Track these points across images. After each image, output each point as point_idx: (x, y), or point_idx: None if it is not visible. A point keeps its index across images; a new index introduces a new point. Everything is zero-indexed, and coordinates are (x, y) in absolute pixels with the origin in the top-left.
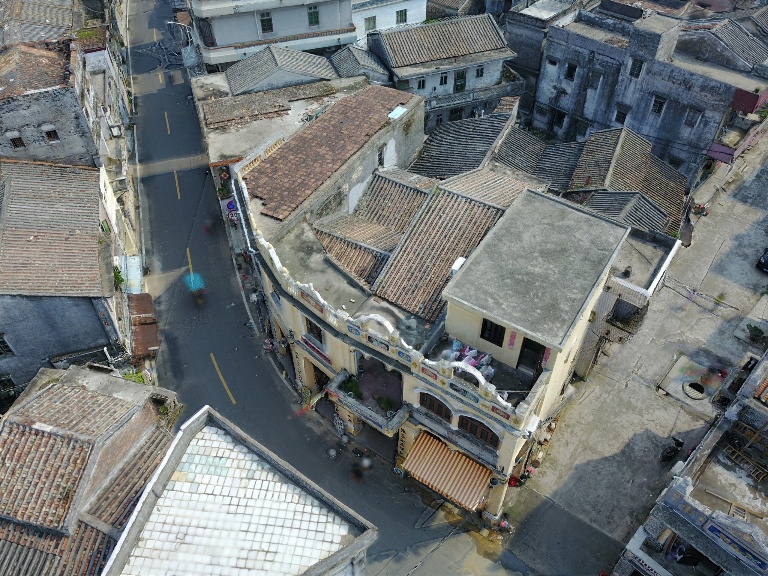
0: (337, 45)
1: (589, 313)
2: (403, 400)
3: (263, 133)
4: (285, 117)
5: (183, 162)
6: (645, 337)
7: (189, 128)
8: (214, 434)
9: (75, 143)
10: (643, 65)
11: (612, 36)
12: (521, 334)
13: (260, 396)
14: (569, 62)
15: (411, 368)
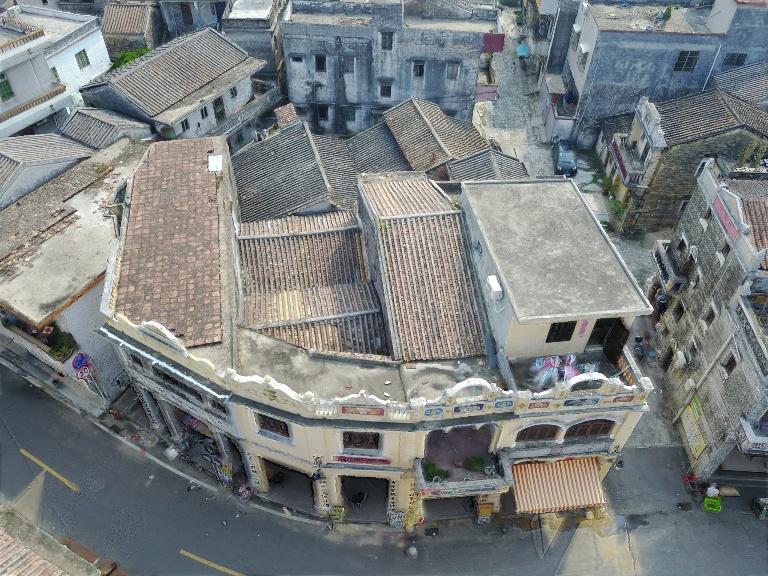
0: (51, 114)
1: None
2: (496, 448)
3: (71, 253)
4: (79, 222)
5: None
6: None
7: None
8: None
9: None
10: (393, 36)
11: (340, 18)
12: (611, 317)
13: (284, 554)
14: (316, 54)
15: (515, 412)
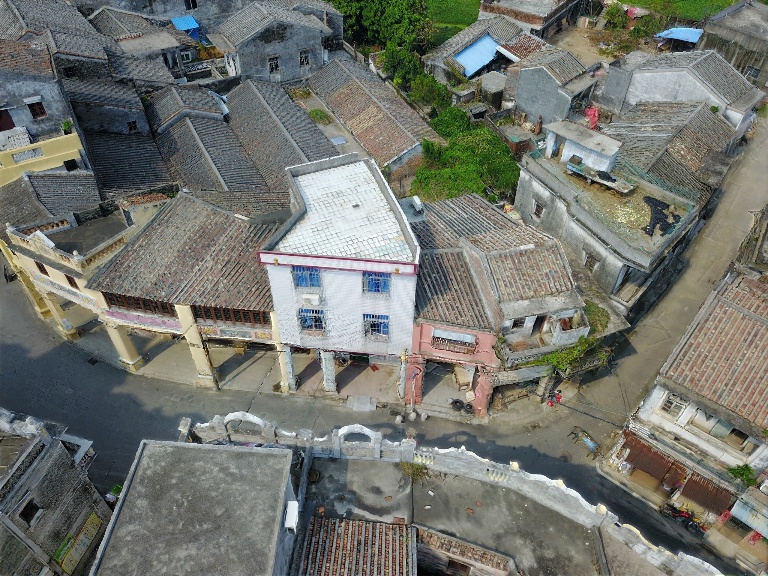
0: None
1: None
2: None
3: None
4: None
5: None
6: None
7: None
8: None
9: None
10: None
11: None
12: None
13: None
14: None
15: None
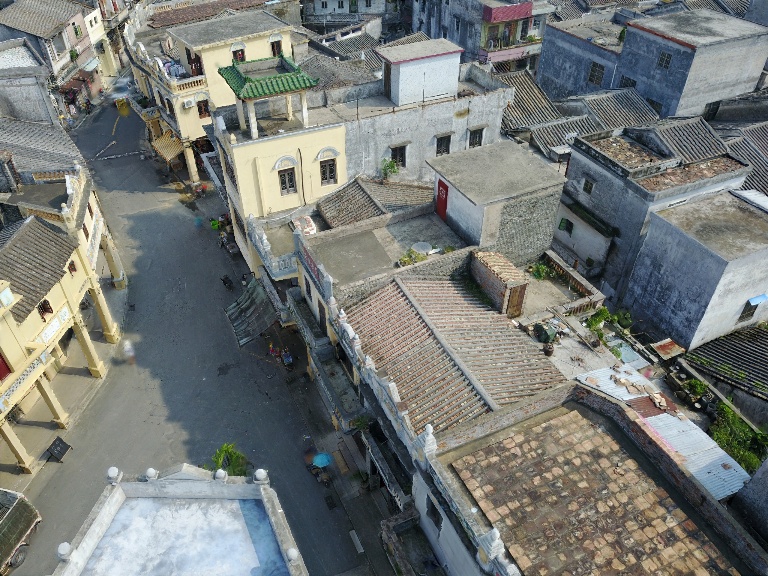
0: None
1: None
2: (156, 103)
3: None
4: (212, 0)
5: None
6: None
7: None
8: (23, 48)
9: None
10: None
11: None
12: None
13: (128, 134)
14: None
15: None
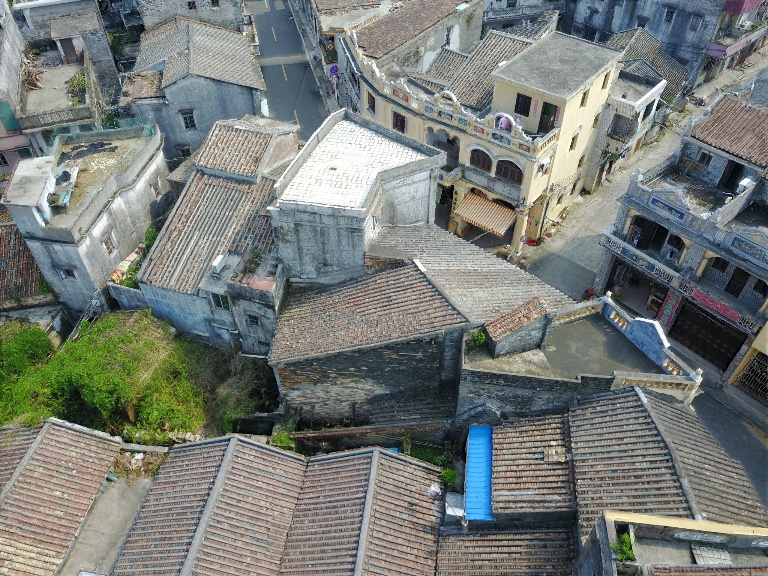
0: None
1: (593, 116)
2: (459, 162)
3: None
4: (377, 8)
5: (288, 59)
6: None
7: (291, 38)
8: (348, 123)
9: (229, 11)
10: None
11: None
12: (541, 94)
13: None
14: None
15: (466, 129)
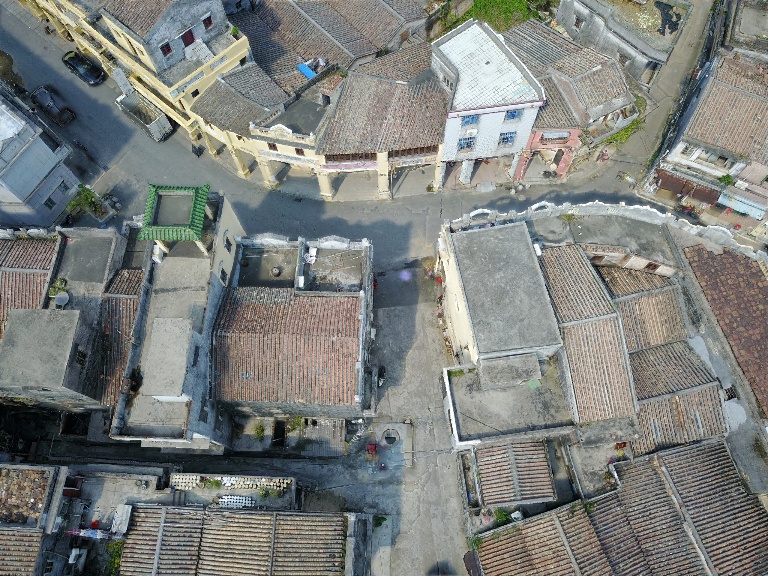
0: None
1: None
2: None
3: None
4: None
5: None
6: (442, 463)
7: None
8: None
9: None
10: None
11: None
12: None
13: None
14: None
15: None
